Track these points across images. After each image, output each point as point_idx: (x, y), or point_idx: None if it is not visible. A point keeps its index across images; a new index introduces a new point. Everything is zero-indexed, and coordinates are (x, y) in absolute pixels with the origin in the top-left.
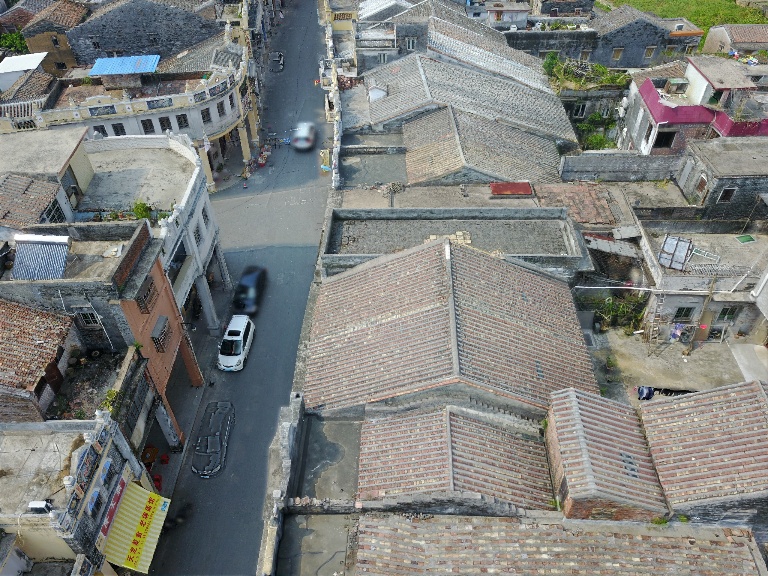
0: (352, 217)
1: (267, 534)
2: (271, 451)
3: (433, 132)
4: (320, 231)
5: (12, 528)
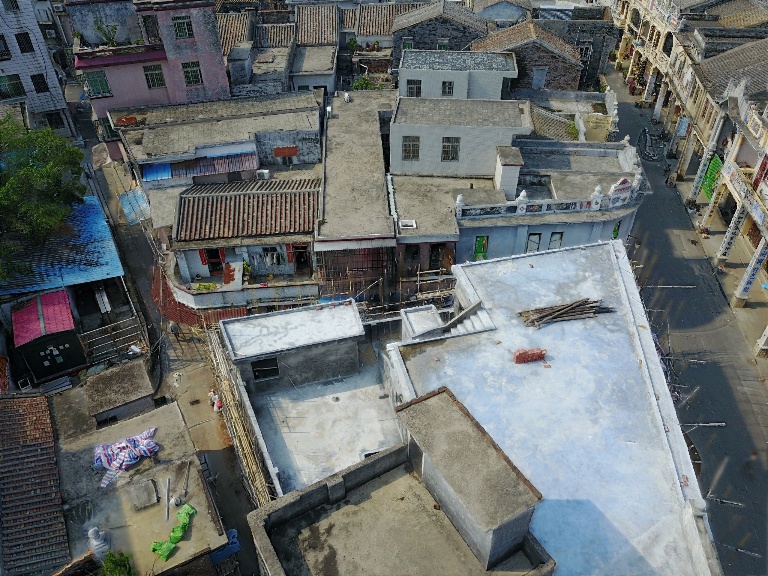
0: (709, 35)
1: (741, 126)
2: (730, 98)
3: (737, 8)
4: (619, 96)
5: (585, 124)
